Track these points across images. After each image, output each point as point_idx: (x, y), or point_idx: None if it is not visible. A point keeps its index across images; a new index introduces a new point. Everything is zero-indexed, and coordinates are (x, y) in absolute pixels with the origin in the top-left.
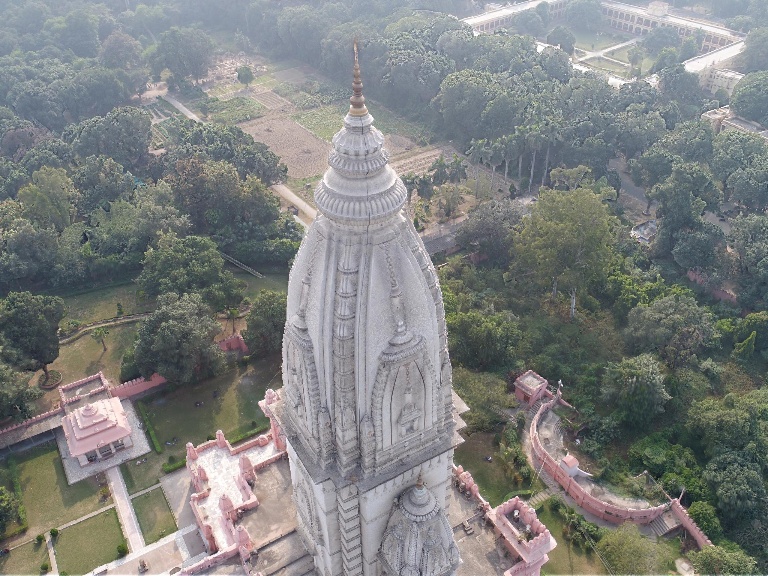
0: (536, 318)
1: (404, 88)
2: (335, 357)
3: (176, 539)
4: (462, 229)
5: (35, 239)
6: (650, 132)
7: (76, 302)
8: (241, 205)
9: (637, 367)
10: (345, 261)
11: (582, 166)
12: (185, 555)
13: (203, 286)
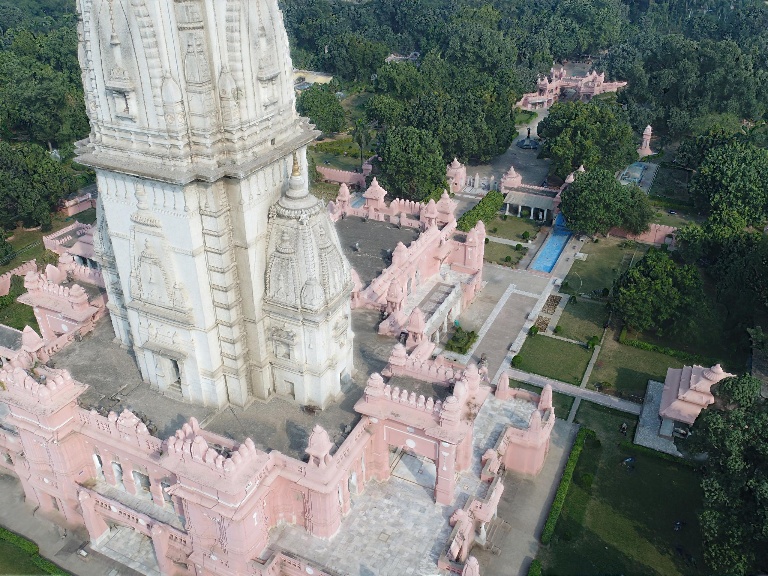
0: None
1: None
2: None
3: None
4: None
5: None
6: None
7: None
8: None
9: None
10: None
11: None
12: None
13: None
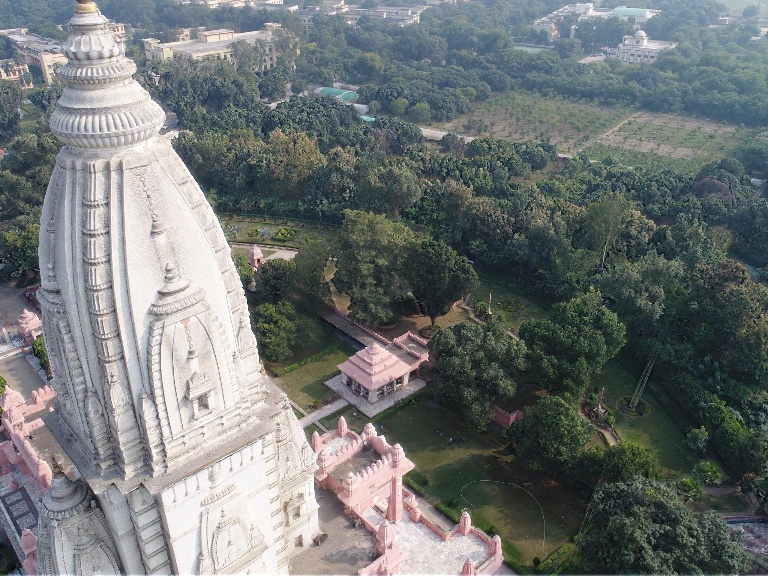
0: None
1: None
2: None
3: None
4: None
5: (551, 240)
6: None
7: (534, 310)
8: (734, 342)
9: None
10: None
11: None
12: None
13: (554, 353)
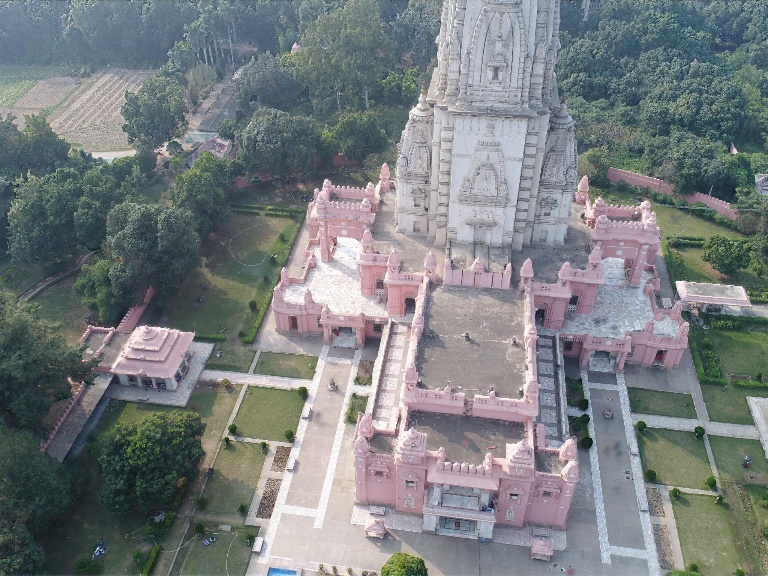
0: None
1: (23, 31)
2: None
3: (326, 361)
4: (241, 94)
5: None
6: None
7: None
8: (32, 151)
9: None
10: None
11: None
12: (347, 361)
13: None
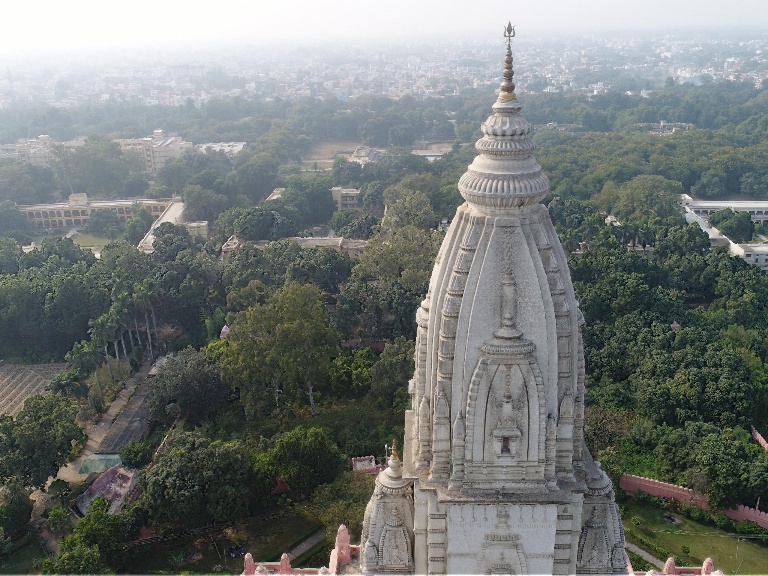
0: None
1: None
2: (562, 341)
3: None
4: (155, 401)
5: None
6: (211, 268)
7: None
8: None
9: None
10: (546, 237)
11: (253, 281)
12: None
13: None
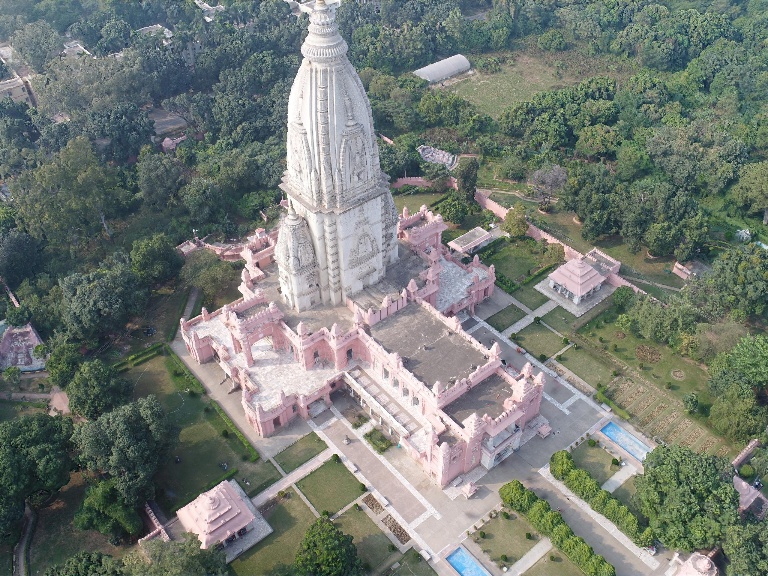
0: (114, 248)
1: None
2: None
3: (322, 430)
4: None
5: None
6: None
7: None
8: None
9: (200, 187)
10: None
11: None
12: (334, 420)
13: None
